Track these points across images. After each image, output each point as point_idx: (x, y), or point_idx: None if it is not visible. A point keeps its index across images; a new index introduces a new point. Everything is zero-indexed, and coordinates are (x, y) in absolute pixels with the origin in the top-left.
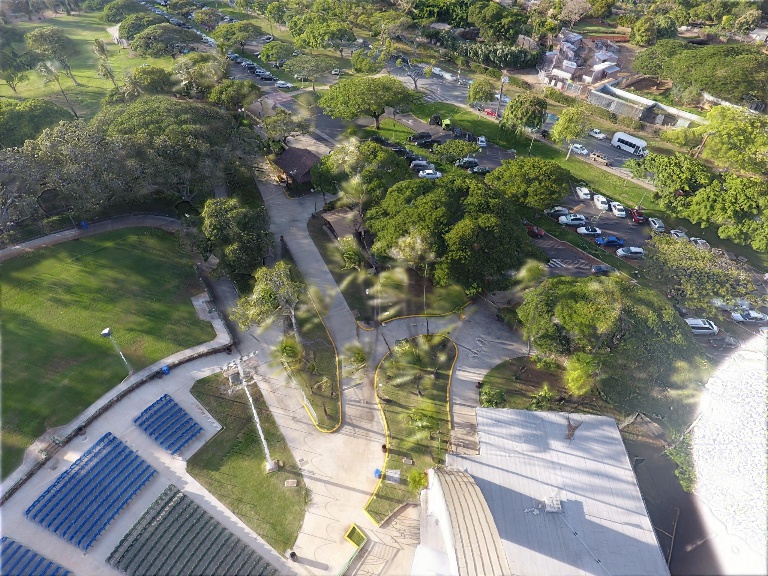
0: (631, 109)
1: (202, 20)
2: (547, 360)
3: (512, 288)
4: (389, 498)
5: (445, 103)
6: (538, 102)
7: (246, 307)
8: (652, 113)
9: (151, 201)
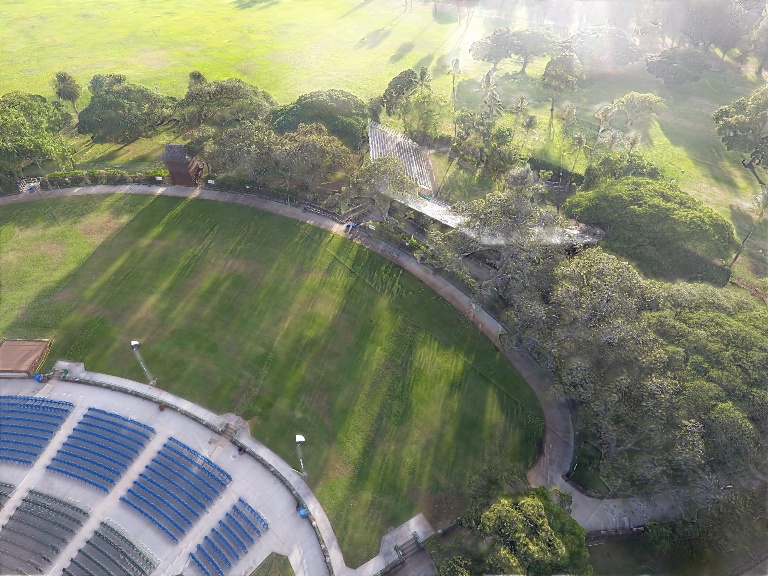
0: None
1: None
2: None
3: None
4: None
5: None
6: None
7: None
8: None
9: None
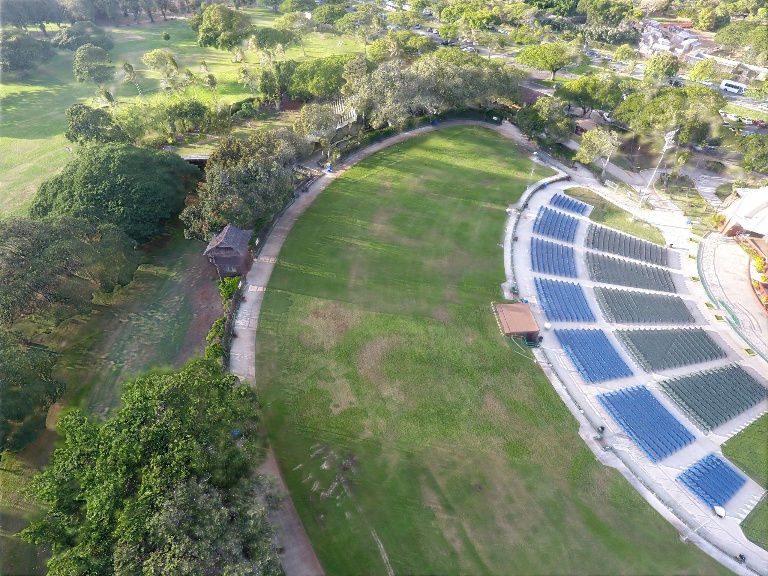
0: (724, 67)
1: (368, 11)
2: (765, 167)
3: (724, 144)
4: (700, 230)
5: (586, 66)
6: (674, 58)
7: (589, 149)
8: (737, 71)
9: (470, 110)
